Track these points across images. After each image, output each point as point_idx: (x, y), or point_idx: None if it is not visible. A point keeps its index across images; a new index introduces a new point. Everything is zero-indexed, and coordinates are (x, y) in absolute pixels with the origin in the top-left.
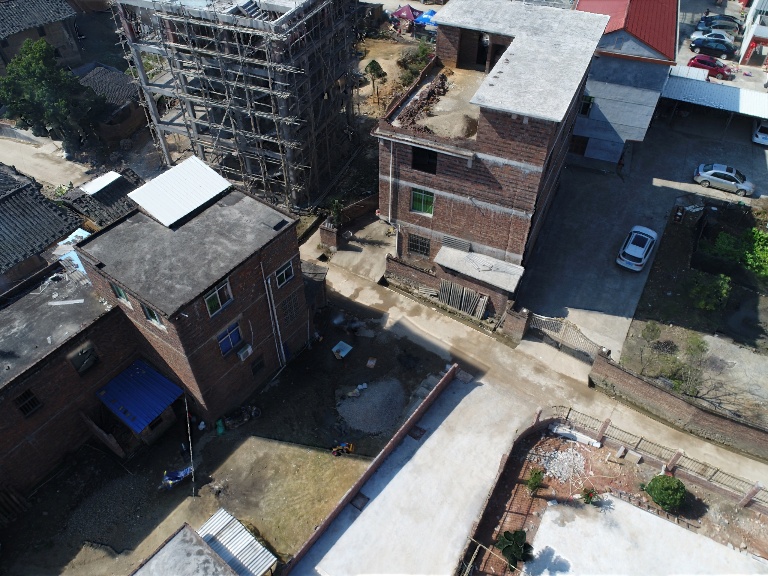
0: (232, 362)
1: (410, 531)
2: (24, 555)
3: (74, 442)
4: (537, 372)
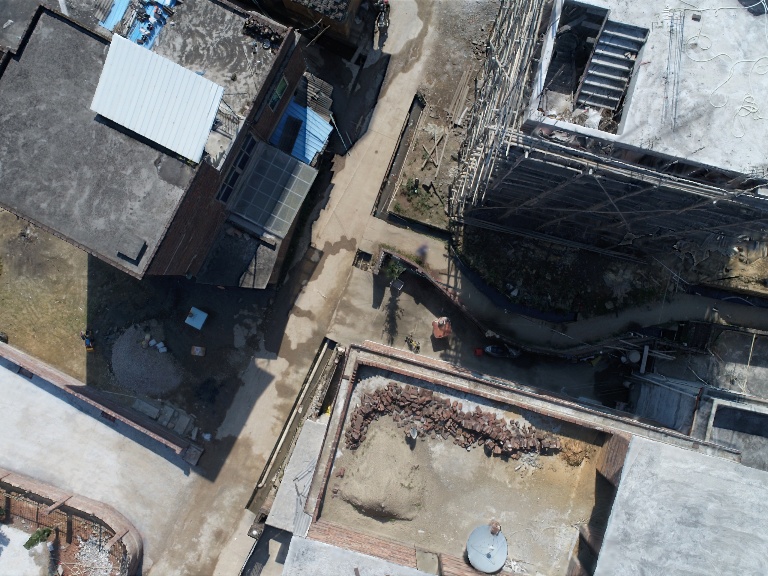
0: None
1: (7, 419)
2: None
3: None
4: (216, 534)
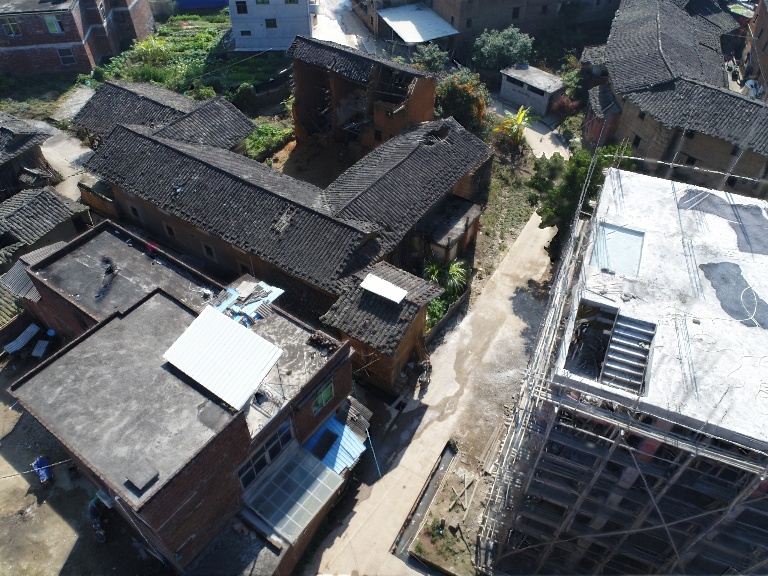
0: None
1: None
2: None
3: None
4: None
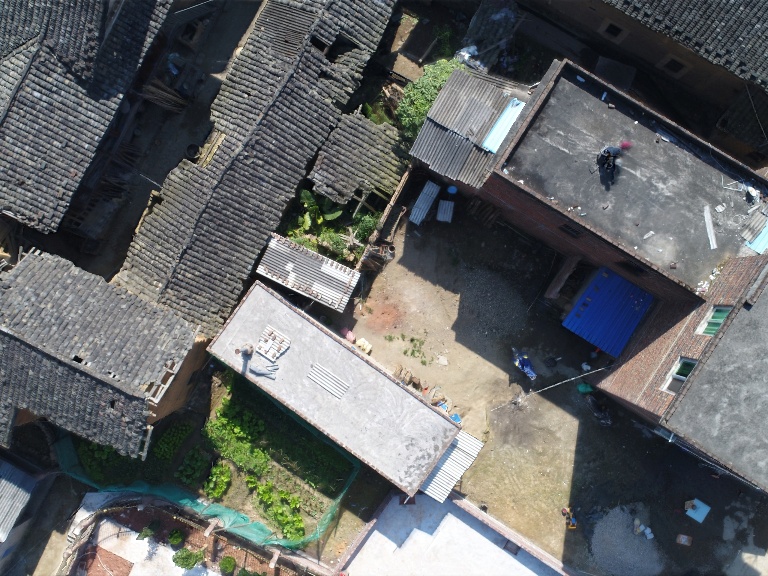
0: (652, 419)
1: None
2: (445, 243)
3: (555, 246)
4: None
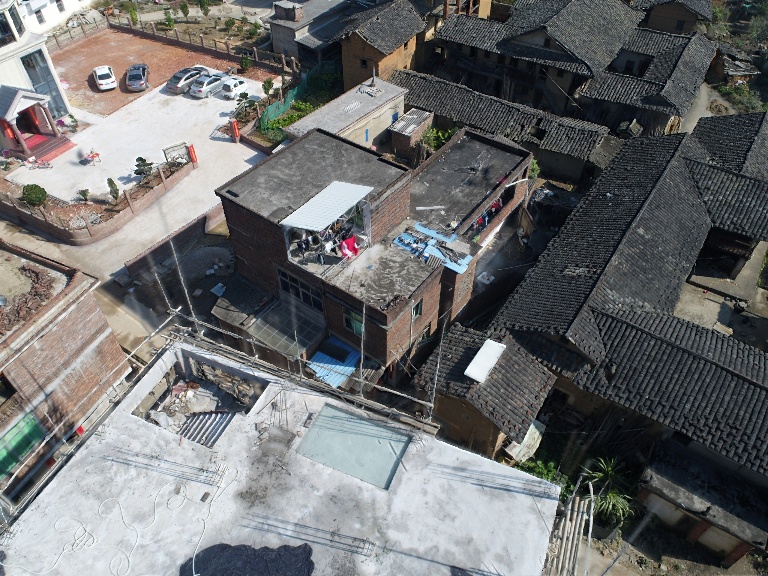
0: None
1: (201, 193)
2: None
3: None
4: None
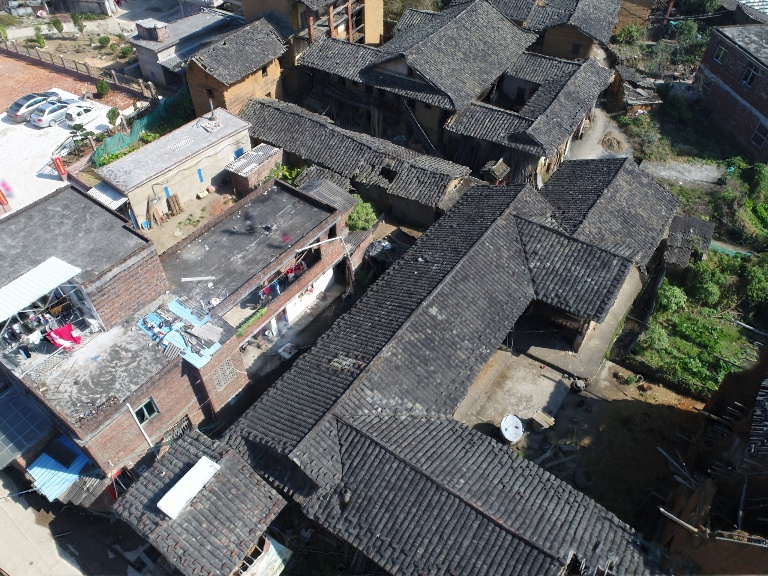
0: None
1: None
2: None
3: None
4: None
